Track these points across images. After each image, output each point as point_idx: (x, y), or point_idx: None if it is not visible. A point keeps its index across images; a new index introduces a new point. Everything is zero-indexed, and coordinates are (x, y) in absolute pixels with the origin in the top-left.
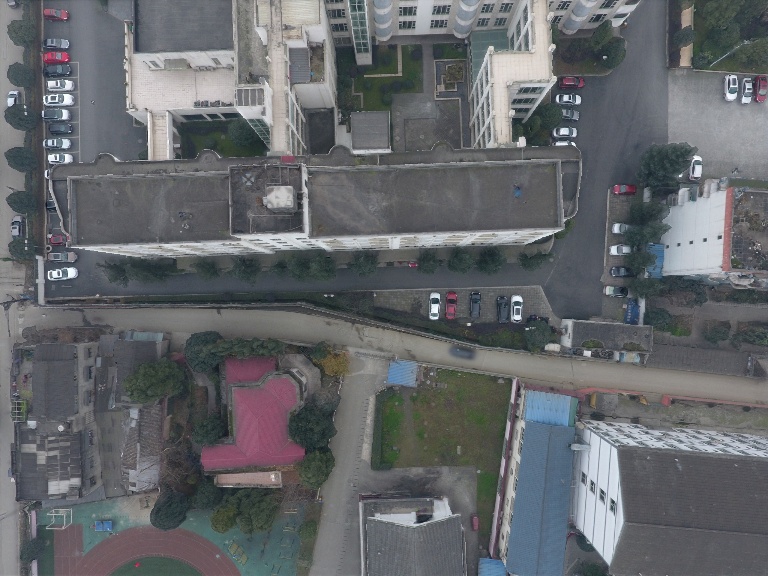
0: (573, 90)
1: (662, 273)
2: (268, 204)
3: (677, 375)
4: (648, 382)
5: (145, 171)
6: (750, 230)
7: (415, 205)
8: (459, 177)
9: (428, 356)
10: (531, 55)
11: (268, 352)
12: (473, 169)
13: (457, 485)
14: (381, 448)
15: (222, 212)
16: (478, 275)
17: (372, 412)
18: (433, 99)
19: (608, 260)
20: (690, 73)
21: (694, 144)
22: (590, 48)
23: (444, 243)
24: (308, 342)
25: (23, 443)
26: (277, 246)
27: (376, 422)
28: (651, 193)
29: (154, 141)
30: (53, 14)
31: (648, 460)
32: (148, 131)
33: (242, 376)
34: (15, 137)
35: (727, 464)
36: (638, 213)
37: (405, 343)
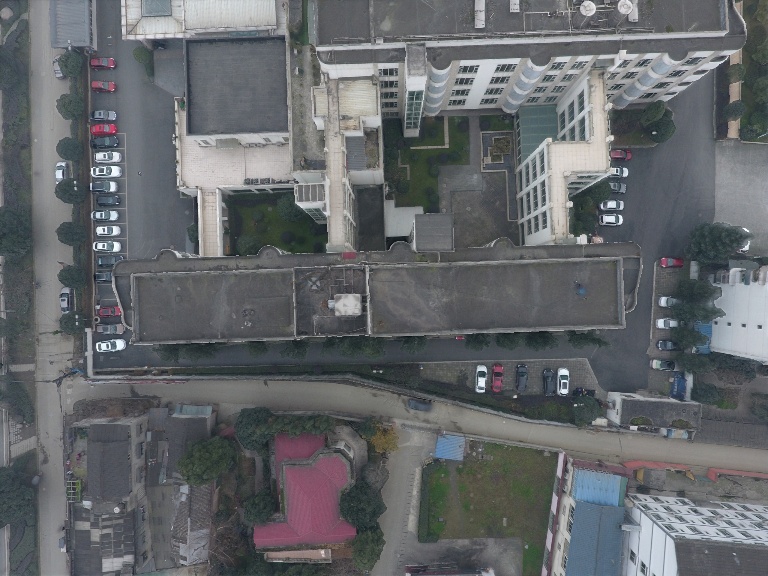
0: (620, 162)
1: (710, 348)
2: (336, 312)
3: (723, 448)
4: (694, 455)
5: (207, 267)
6: None
7: (475, 301)
8: (519, 273)
9: (474, 428)
10: (588, 145)
11: (320, 432)
12: (533, 265)
13: (503, 557)
14: (428, 520)
15: (283, 308)
16: (525, 348)
17: (418, 484)
18: (479, 171)
19: (654, 333)
20: (737, 144)
21: (741, 216)
22: (637, 120)
23: None
24: (355, 414)
25: (77, 520)
26: None
27: (423, 495)
28: (699, 268)
29: (204, 217)
30: (101, 86)
31: (706, 554)
32: (198, 208)
33: (292, 453)
34: (62, 208)
35: None
36: (688, 291)
37: (451, 415)
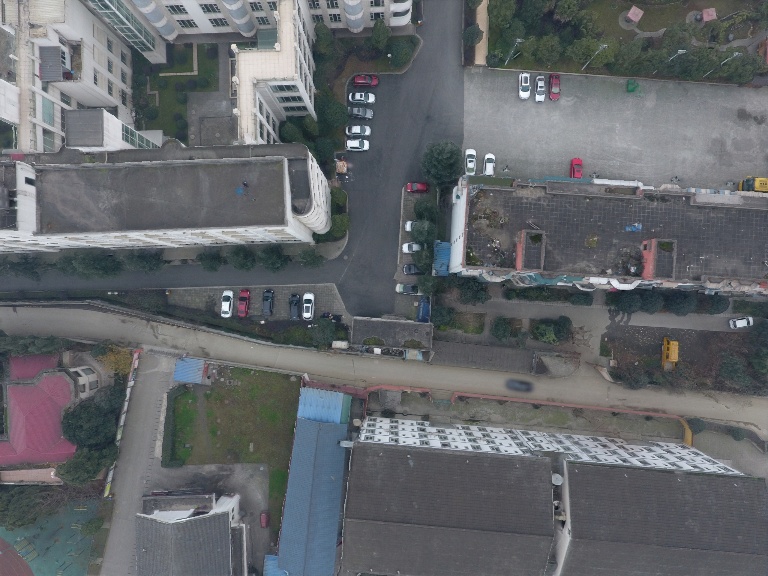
0: (368, 88)
1: (448, 271)
2: None
3: (469, 372)
4: (440, 379)
5: None
6: (488, 227)
7: (145, 203)
8: (189, 175)
9: (222, 354)
10: (277, 53)
11: (38, 349)
12: (203, 167)
13: (249, 482)
14: (173, 445)
15: None
16: (270, 273)
17: None
18: (228, 97)
19: (402, 258)
20: (486, 71)
21: (489, 142)
22: None
23: (215, 241)
24: (102, 340)
25: None
26: (45, 244)
27: (166, 419)
28: (439, 191)
29: None
30: None
31: (381, 456)
32: None
33: (22, 374)
34: None
35: (460, 460)
36: (416, 211)
37: (199, 341)
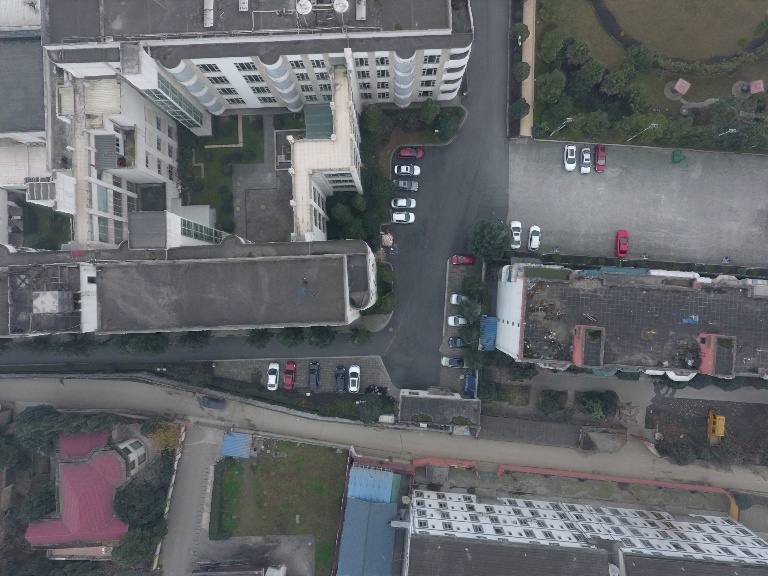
0: (413, 160)
1: (495, 345)
2: (34, 309)
3: (514, 445)
4: (485, 452)
5: None
6: (545, 319)
7: (204, 299)
8: (248, 271)
9: (268, 425)
10: (333, 143)
11: (91, 430)
12: (262, 263)
13: (296, 554)
14: (220, 517)
15: None
16: None
17: (212, 481)
18: (273, 169)
19: (447, 330)
20: (531, 142)
21: (534, 214)
22: None
23: None
24: (149, 412)
25: None
26: None
27: (214, 492)
28: (486, 265)
29: None
30: None
31: (439, 549)
32: None
33: (72, 451)
34: None
35: (517, 553)
36: None
37: (245, 413)
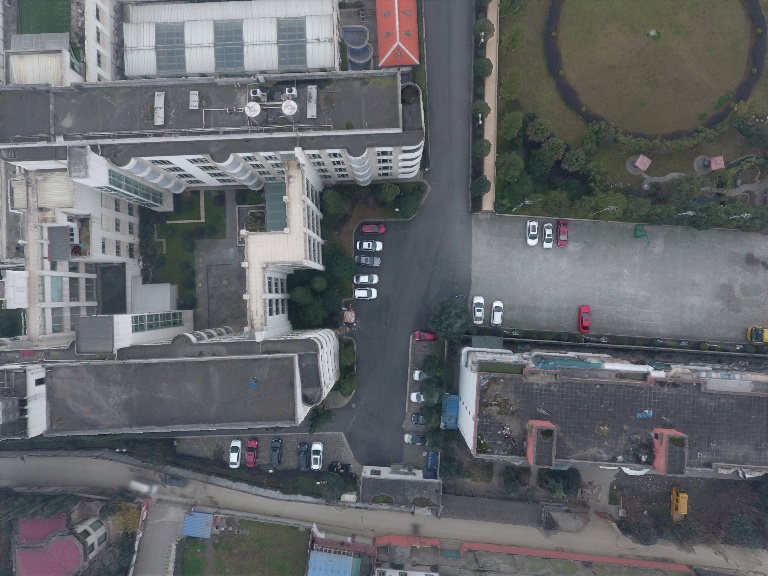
0: (375, 235)
1: (457, 424)
2: None
3: (478, 522)
4: (449, 529)
5: None
6: (499, 414)
7: (155, 398)
8: (199, 370)
9: (230, 502)
10: (287, 235)
11: (47, 517)
12: (213, 362)
13: None
14: None
15: None
16: None
17: (174, 559)
18: (236, 245)
19: (410, 406)
20: (493, 217)
21: (497, 288)
22: None
23: None
24: (110, 489)
25: None
26: None
27: (175, 572)
28: (447, 343)
29: None
30: None
31: None
32: None
33: (30, 534)
34: None
35: None
36: None
37: (208, 490)
